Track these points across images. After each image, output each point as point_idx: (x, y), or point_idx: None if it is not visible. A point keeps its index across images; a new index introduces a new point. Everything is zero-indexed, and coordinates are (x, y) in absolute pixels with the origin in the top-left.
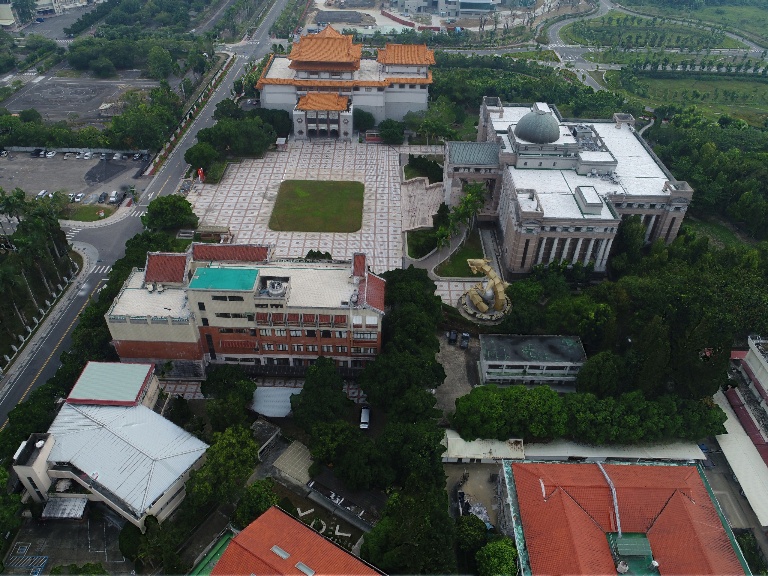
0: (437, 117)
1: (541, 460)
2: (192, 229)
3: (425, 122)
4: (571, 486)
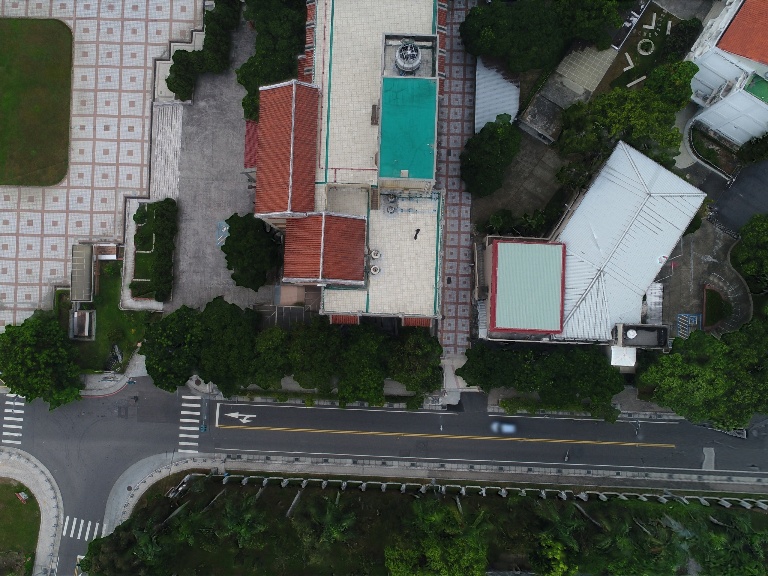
0: None
1: None
2: (65, 319)
3: None
4: None
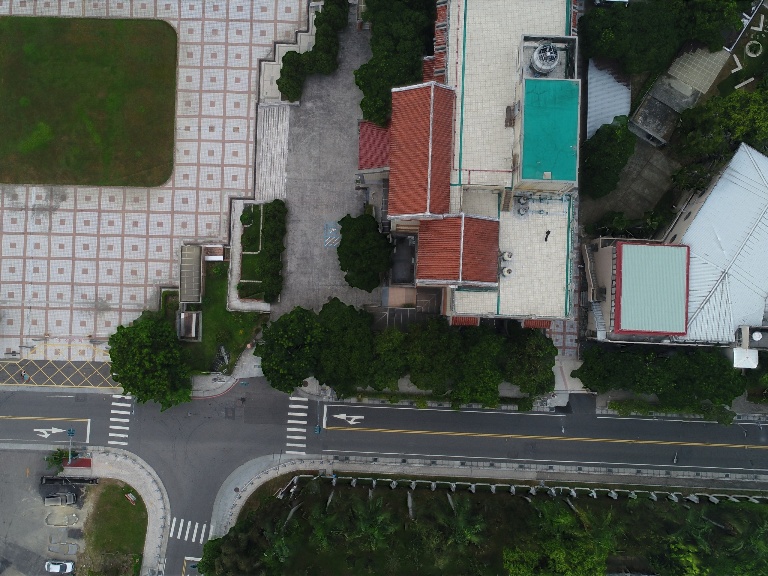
0: None
1: None
2: (172, 320)
3: None
4: None
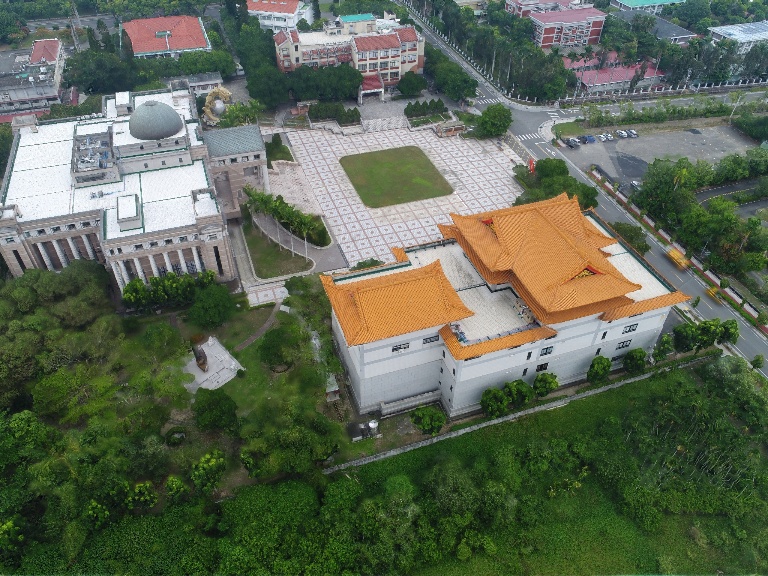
0: (304, 279)
1: (194, 49)
2: None
3: (309, 216)
4: (183, 36)
